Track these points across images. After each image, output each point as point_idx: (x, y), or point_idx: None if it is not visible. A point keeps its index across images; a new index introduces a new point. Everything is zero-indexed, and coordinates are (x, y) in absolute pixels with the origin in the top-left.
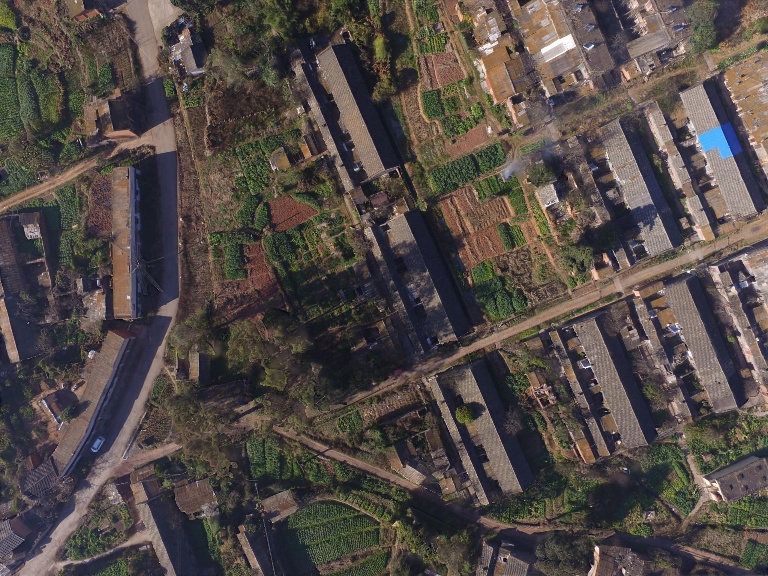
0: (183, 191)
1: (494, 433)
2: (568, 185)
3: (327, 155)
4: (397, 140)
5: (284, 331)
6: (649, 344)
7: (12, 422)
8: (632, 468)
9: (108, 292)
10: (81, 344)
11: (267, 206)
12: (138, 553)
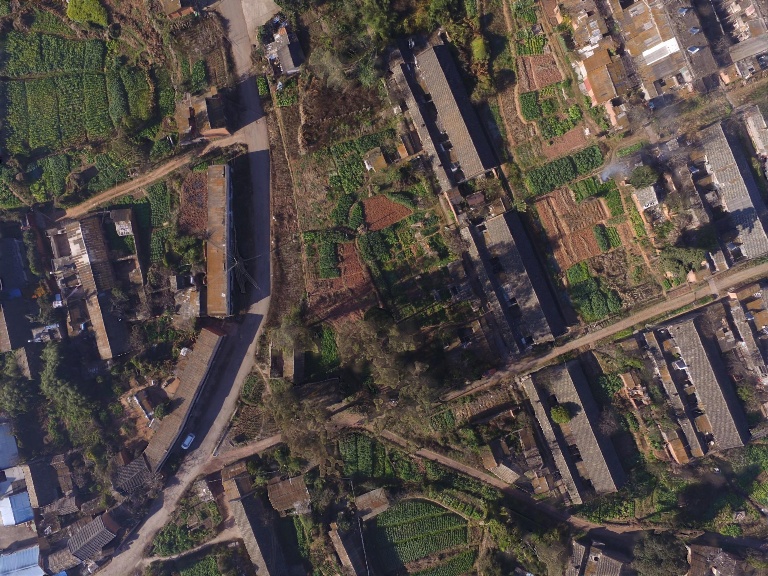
0: (275, 189)
1: (589, 433)
2: (667, 187)
3: (422, 155)
4: (494, 141)
5: (399, 330)
6: (743, 346)
7: (101, 418)
8: (723, 469)
9: (202, 289)
10: (172, 341)
11: (361, 205)
12: (227, 550)
